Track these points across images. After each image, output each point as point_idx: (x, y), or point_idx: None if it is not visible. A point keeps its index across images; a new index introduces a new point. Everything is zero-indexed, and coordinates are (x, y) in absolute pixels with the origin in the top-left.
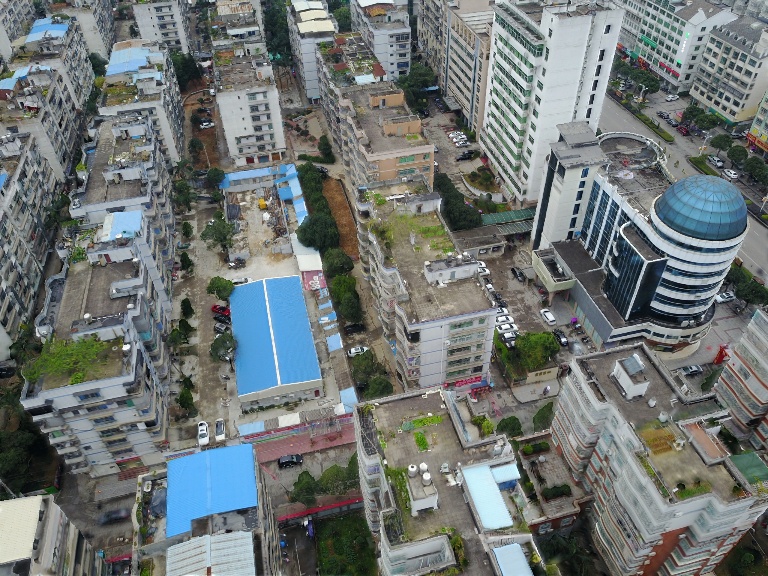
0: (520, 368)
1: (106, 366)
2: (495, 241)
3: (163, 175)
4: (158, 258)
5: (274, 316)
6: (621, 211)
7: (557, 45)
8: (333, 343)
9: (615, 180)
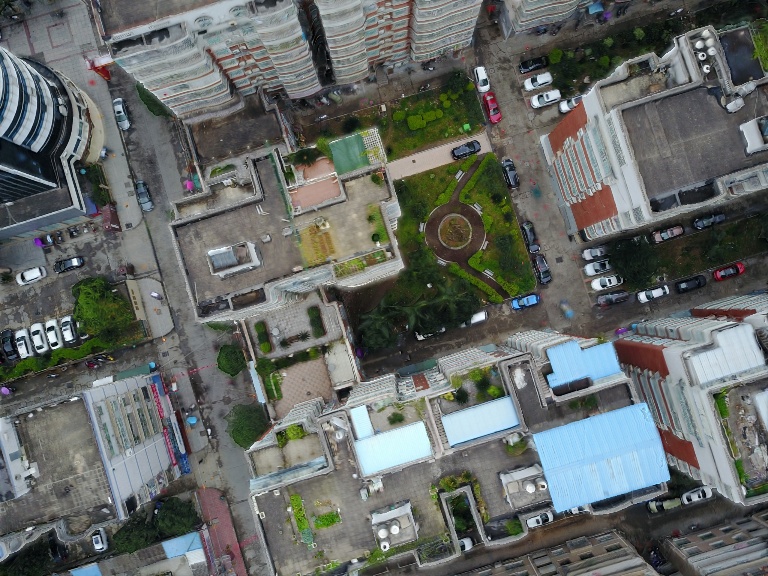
0: (127, 328)
1: None
2: None
3: None
4: None
5: None
6: None
7: None
8: None
9: None
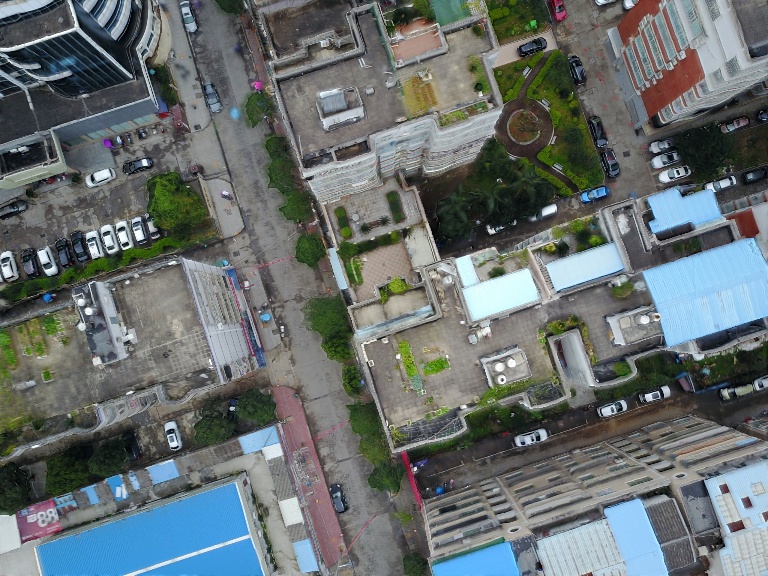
0: (200, 226)
1: None
2: None
3: None
4: None
5: (127, 569)
6: None
7: None
8: (164, 474)
9: None
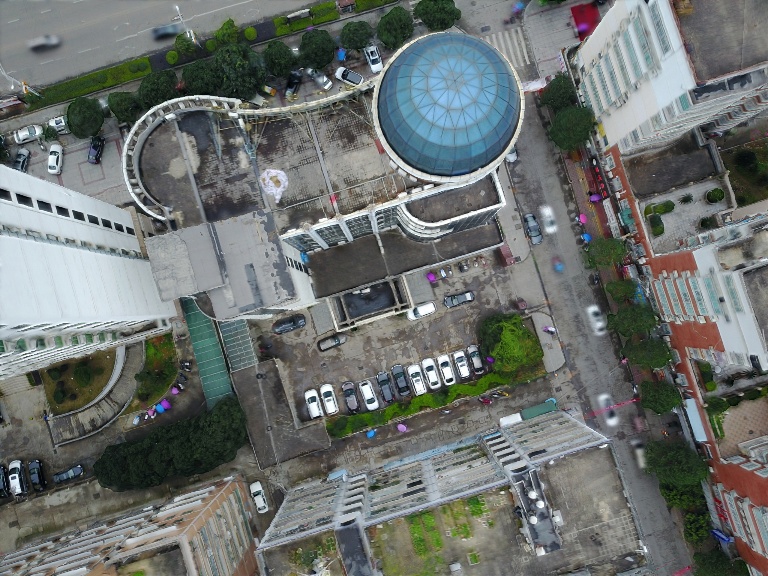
0: None
1: None
2: (274, 377)
3: None
4: None
5: None
6: None
7: None
8: None
9: (291, 205)
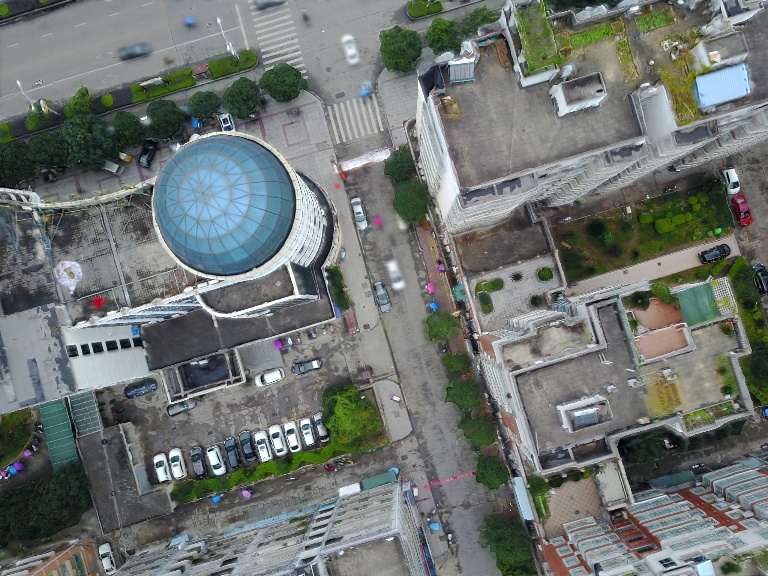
0: (372, 434)
1: None
2: (118, 443)
3: None
4: None
5: None
6: (169, 304)
7: None
8: None
9: (85, 296)
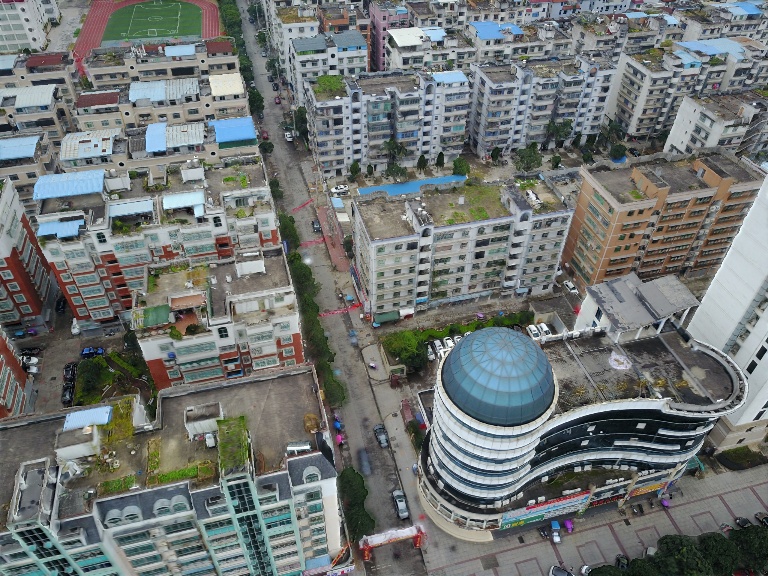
0: None
1: (327, 97)
2: None
3: (568, 108)
4: (459, 120)
5: None
6: None
7: (760, 197)
8: None
9: (602, 348)
